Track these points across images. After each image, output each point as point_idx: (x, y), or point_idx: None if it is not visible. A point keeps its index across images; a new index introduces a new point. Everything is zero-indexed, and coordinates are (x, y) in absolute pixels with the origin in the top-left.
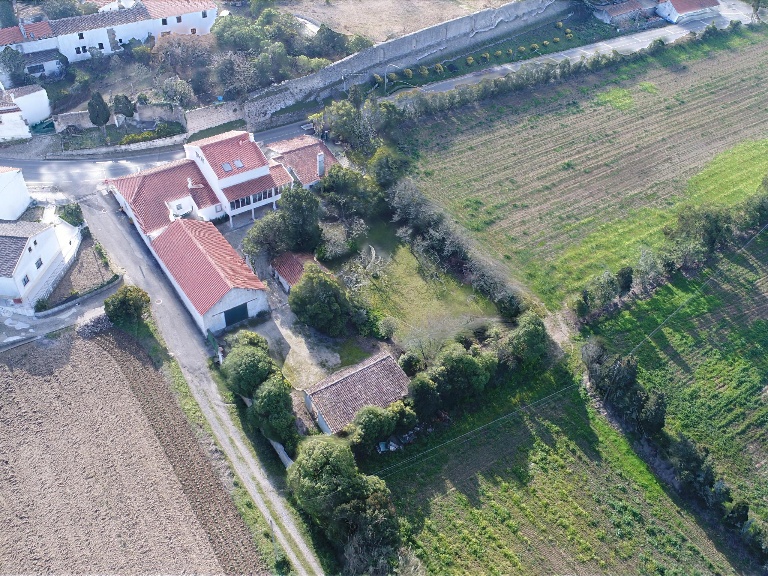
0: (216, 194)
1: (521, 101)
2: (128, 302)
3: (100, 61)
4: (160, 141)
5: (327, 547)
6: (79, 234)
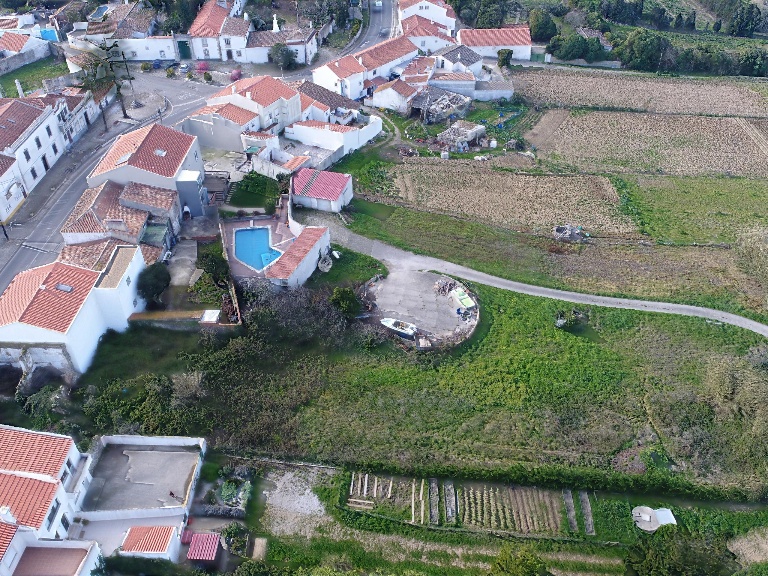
0: (441, 23)
1: None
2: (511, 53)
3: None
4: None
5: (653, 70)
6: None
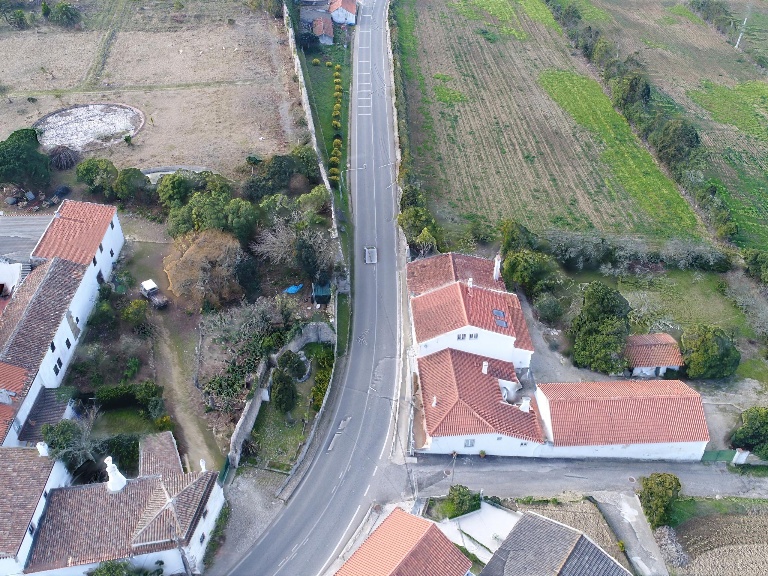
0: (501, 359)
1: (421, 133)
2: (677, 492)
3: (86, 363)
4: None
5: None
6: (499, 509)
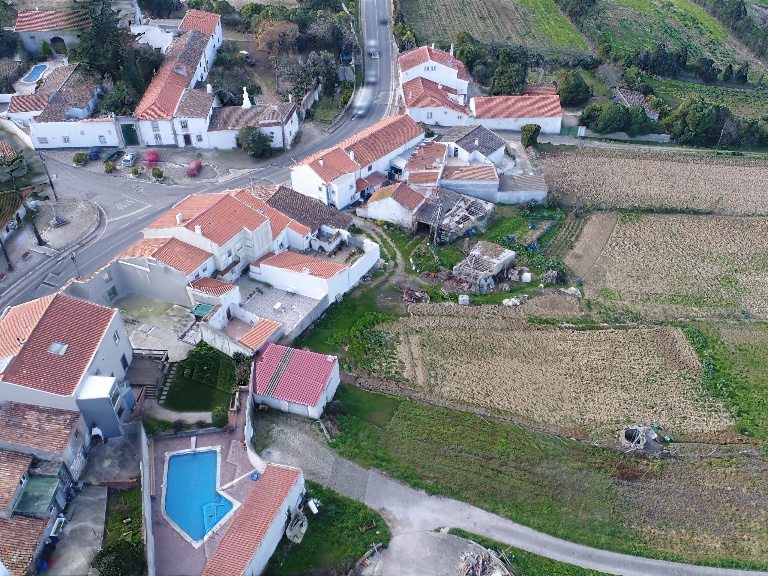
0: (450, 86)
1: (409, 4)
2: (538, 130)
3: None
4: (352, 94)
5: (709, 145)
6: None
